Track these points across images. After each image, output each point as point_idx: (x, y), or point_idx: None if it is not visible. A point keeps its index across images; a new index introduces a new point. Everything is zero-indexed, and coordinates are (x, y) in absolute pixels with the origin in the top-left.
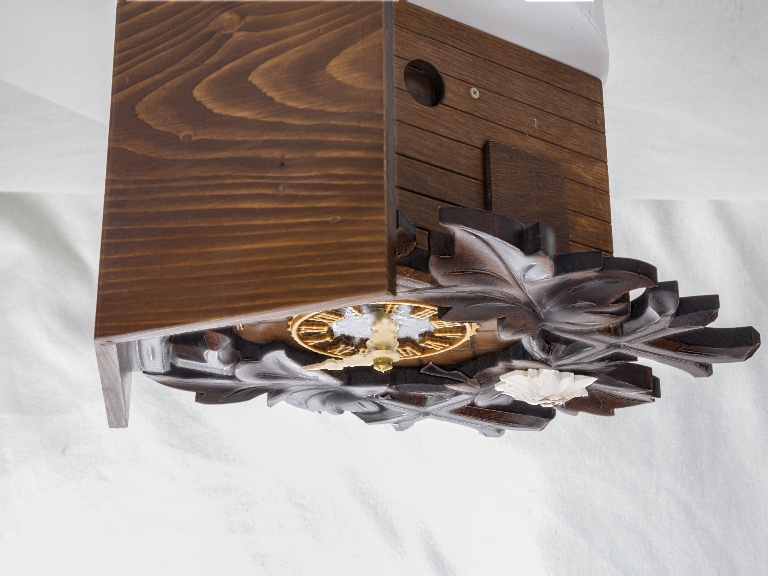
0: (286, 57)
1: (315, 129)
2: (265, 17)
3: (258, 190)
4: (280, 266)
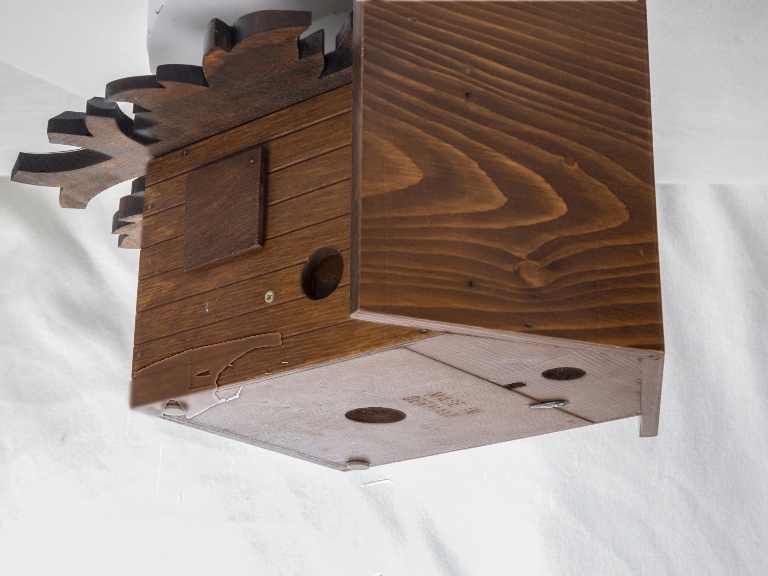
0: (467, 207)
1: (434, 116)
2: (492, 262)
3: (492, 78)
4: None
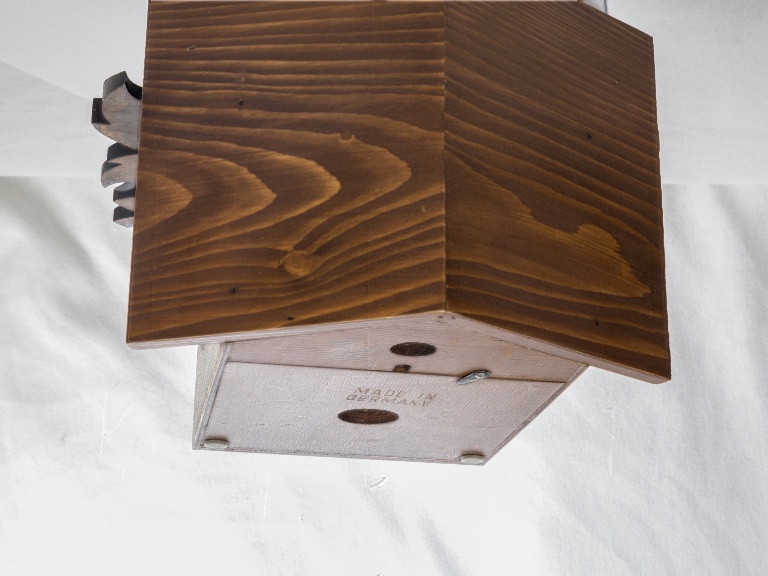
0: (234, 215)
1: (206, 135)
2: (256, 263)
3: (266, 77)
4: (245, 6)
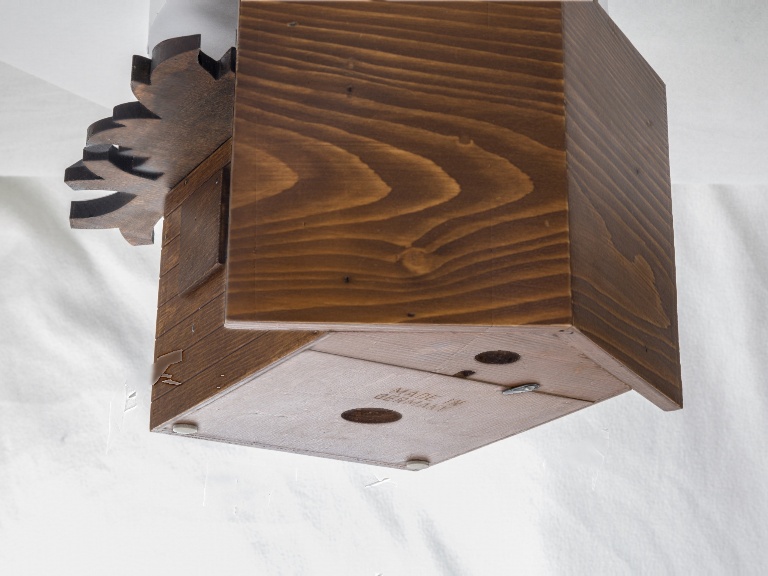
0: (345, 203)
1: (312, 117)
2: (371, 255)
3: (377, 68)
4: None
